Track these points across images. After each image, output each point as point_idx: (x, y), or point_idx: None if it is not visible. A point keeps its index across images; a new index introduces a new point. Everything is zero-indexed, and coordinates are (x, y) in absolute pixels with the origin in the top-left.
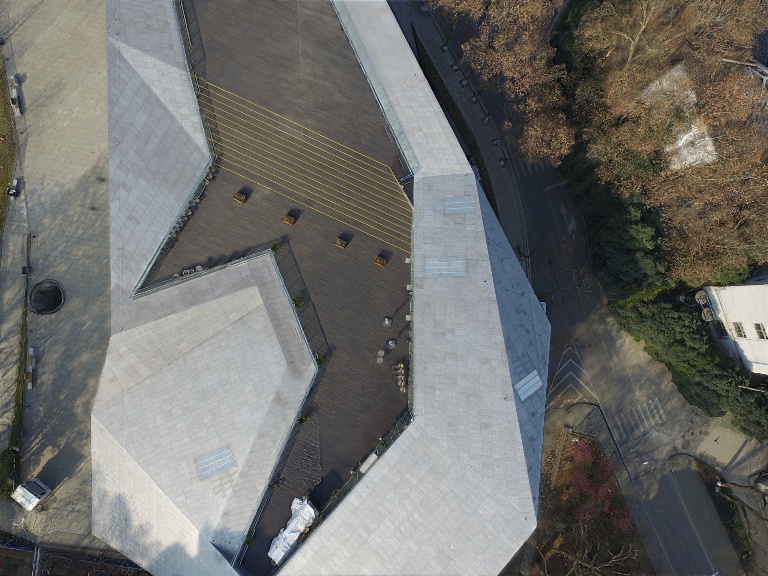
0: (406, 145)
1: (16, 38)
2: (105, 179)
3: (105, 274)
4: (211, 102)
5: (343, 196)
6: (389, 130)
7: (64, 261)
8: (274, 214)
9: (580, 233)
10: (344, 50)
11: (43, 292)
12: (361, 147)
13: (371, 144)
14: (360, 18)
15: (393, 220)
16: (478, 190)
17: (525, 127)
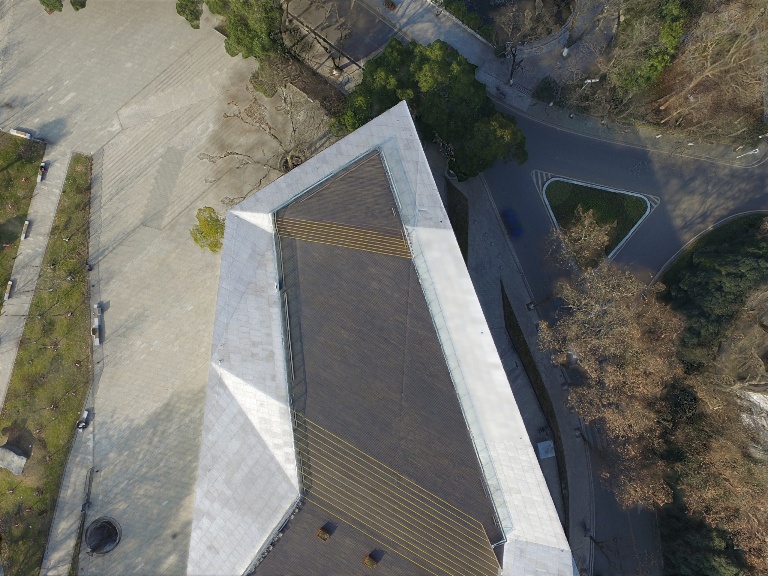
0: (501, 503)
1: (104, 265)
2: (175, 418)
3: (163, 516)
4: (307, 437)
5: (429, 544)
6: (485, 484)
7: (124, 499)
8: (356, 553)
9: (650, 514)
10: (448, 395)
11: (99, 527)
12: (455, 500)
13: (465, 497)
14: (469, 367)
15: (478, 573)
16: (574, 572)
17: (622, 476)
